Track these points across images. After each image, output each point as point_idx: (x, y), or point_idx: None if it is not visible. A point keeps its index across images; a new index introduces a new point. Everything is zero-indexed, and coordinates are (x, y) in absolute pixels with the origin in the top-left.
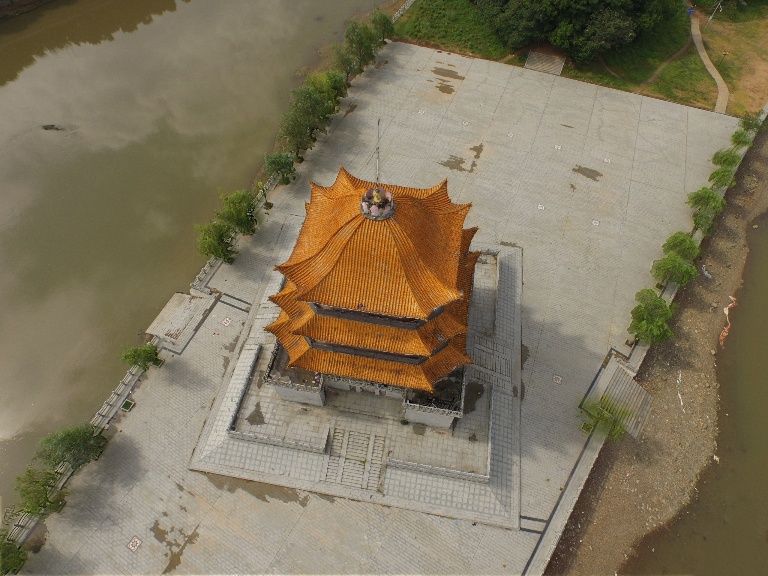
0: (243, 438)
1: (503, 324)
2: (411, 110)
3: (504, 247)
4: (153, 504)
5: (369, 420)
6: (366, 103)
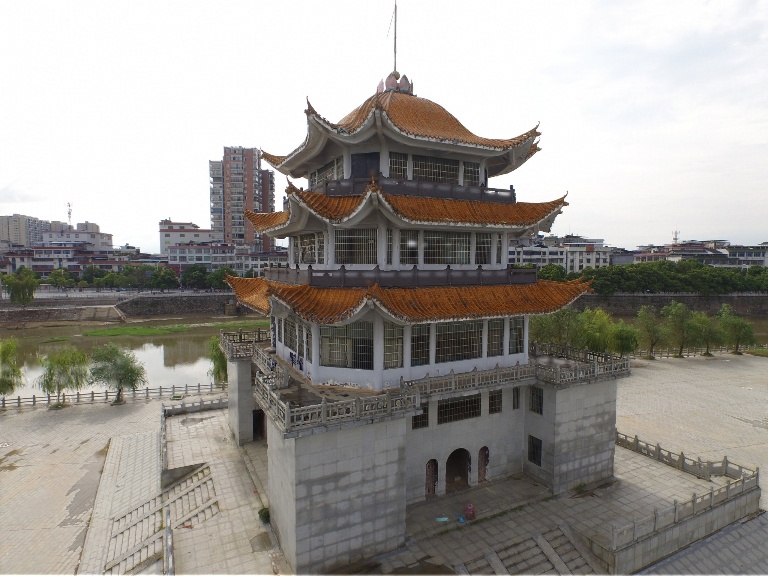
0: None
1: None
2: (729, 383)
3: None
4: (60, 437)
5: (244, 485)
6: (662, 368)
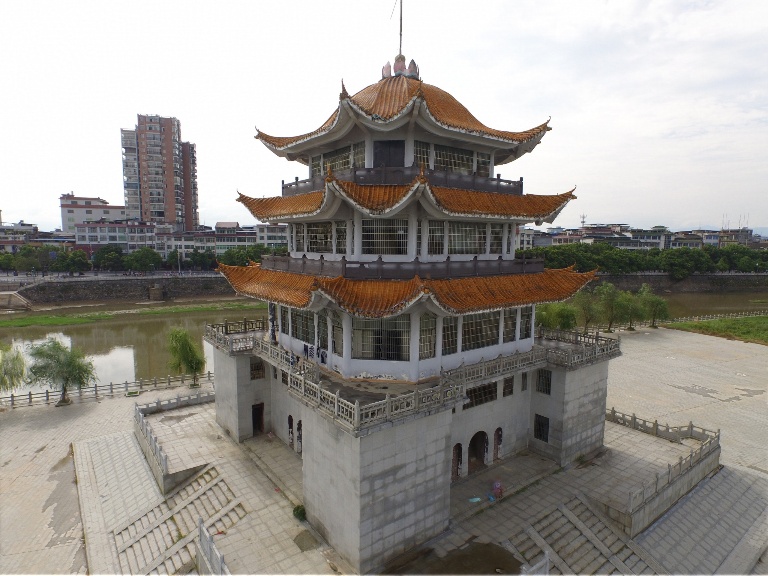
0: None
1: (679, 542)
2: (656, 355)
3: (754, 471)
4: (7, 446)
5: (262, 484)
6: None
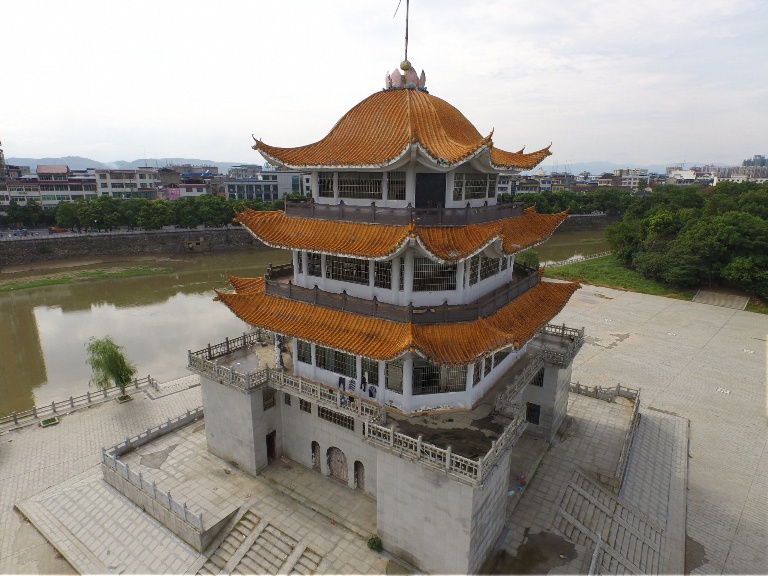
0: (115, 482)
1: (642, 488)
2: None
3: (654, 411)
4: None
5: (313, 519)
6: None
